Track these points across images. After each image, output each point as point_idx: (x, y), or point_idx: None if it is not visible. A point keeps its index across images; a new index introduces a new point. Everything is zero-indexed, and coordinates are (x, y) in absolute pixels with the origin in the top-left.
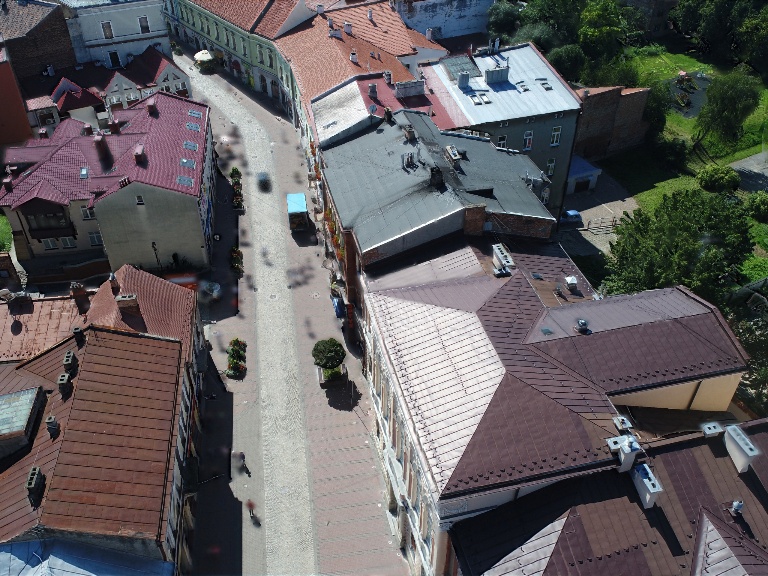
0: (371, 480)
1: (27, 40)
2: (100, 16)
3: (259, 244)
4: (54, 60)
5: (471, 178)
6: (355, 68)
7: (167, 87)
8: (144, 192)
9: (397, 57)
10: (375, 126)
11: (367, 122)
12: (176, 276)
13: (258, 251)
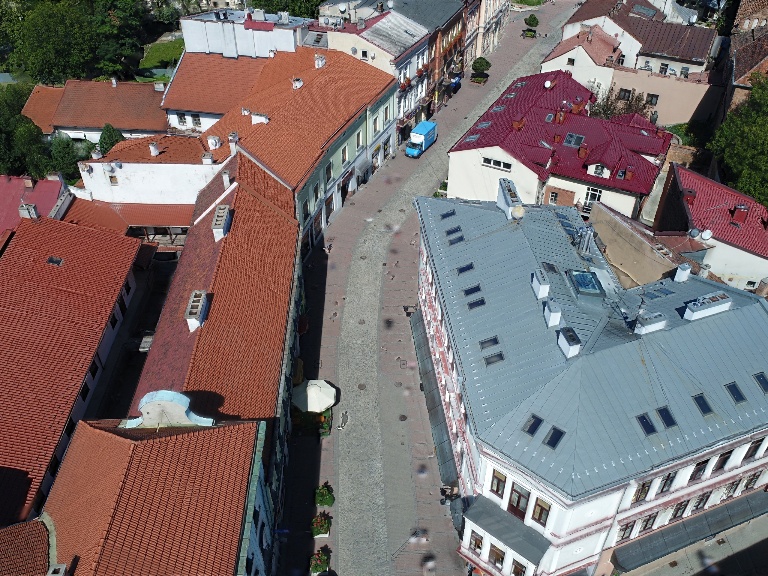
0: (493, 56)
1: None
2: None
3: None
4: None
5: None
6: None
7: None
8: None
9: (198, 136)
10: None
11: None
12: None
13: None
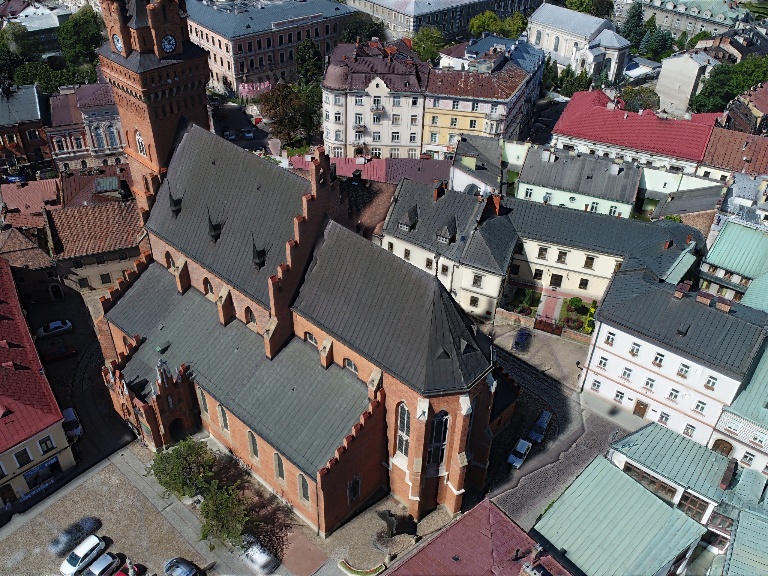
0: None
1: None
2: None
3: None
4: None
5: None
6: None
7: None
8: None
9: None
10: None
11: None
12: None
13: None
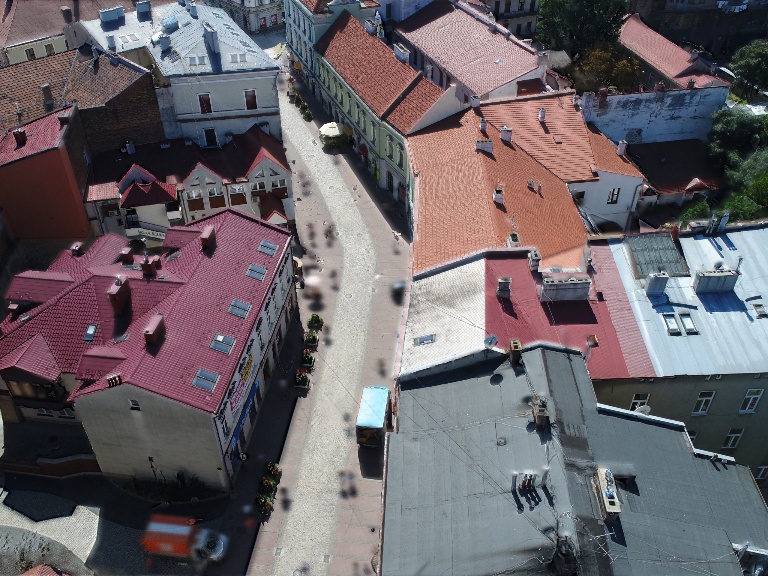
0: None
1: (106, 110)
2: (198, 86)
3: (309, 459)
4: (137, 134)
5: (634, 555)
6: (496, 216)
7: (261, 183)
8: (140, 396)
9: (567, 184)
10: (491, 365)
11: (479, 356)
12: (180, 499)
13: (304, 472)
